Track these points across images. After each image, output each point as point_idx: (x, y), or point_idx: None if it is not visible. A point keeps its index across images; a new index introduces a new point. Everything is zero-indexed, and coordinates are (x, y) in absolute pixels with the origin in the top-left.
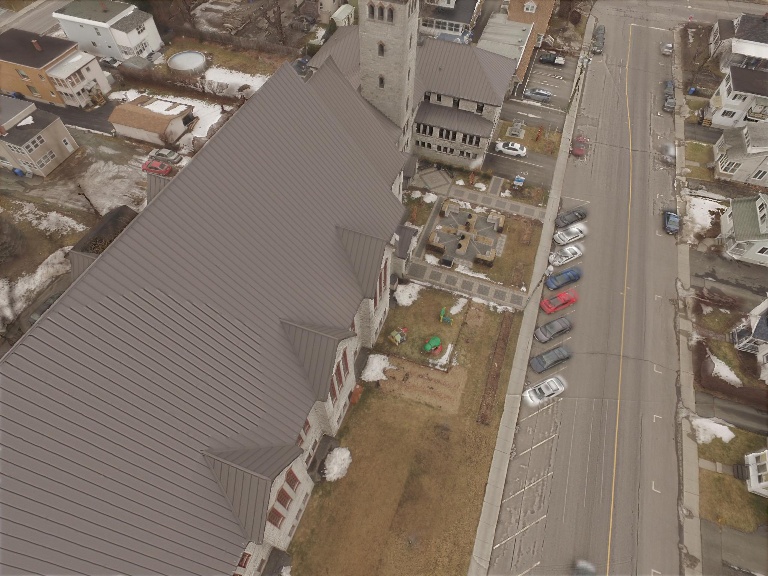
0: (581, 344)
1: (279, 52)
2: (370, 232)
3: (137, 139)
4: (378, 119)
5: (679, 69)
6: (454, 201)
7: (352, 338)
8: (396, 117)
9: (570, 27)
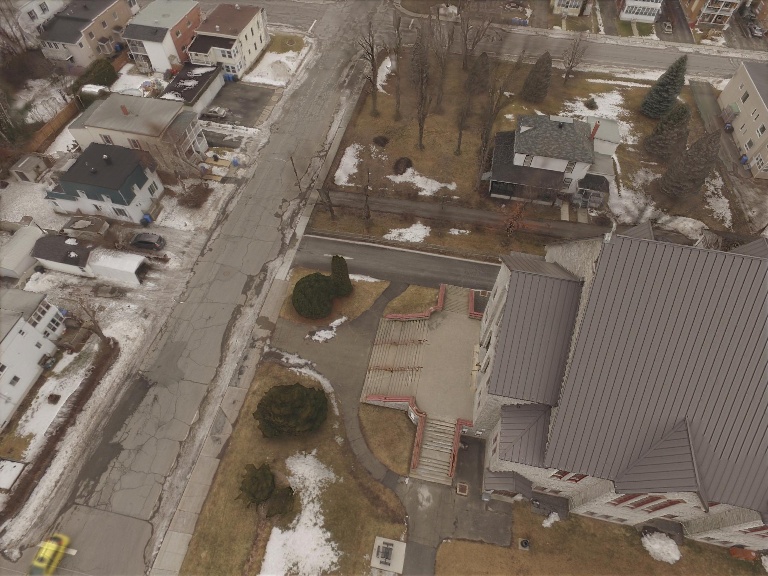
0: None
1: None
2: None
3: None
4: None
5: None
6: None
7: None
8: None
9: None
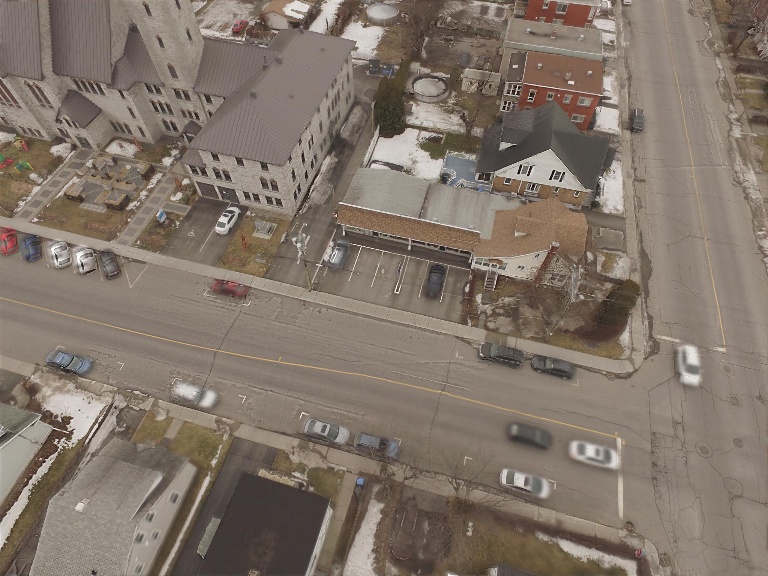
0: None
1: None
2: (2, 52)
3: None
4: None
5: (452, 491)
6: (158, 176)
7: None
8: None
9: (540, 311)
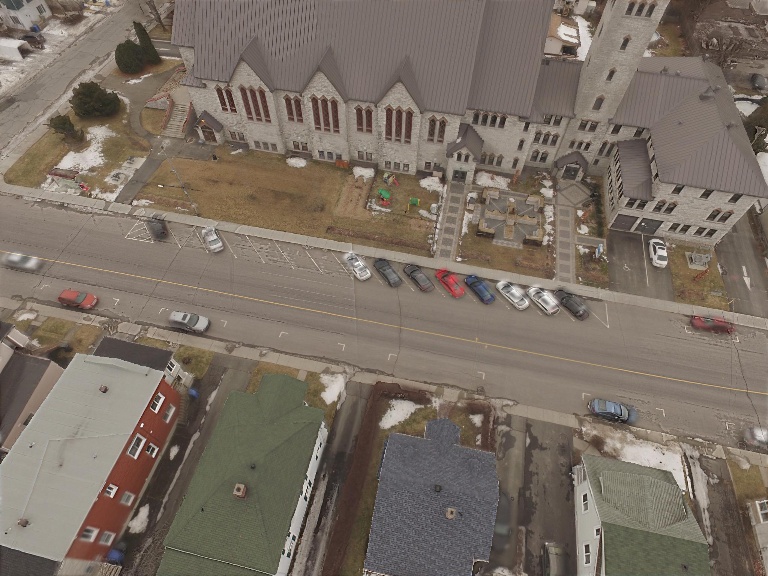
0: (408, 297)
1: None
2: (423, 88)
3: None
4: (568, 91)
5: None
6: (550, 208)
7: (367, 133)
8: (577, 100)
9: None
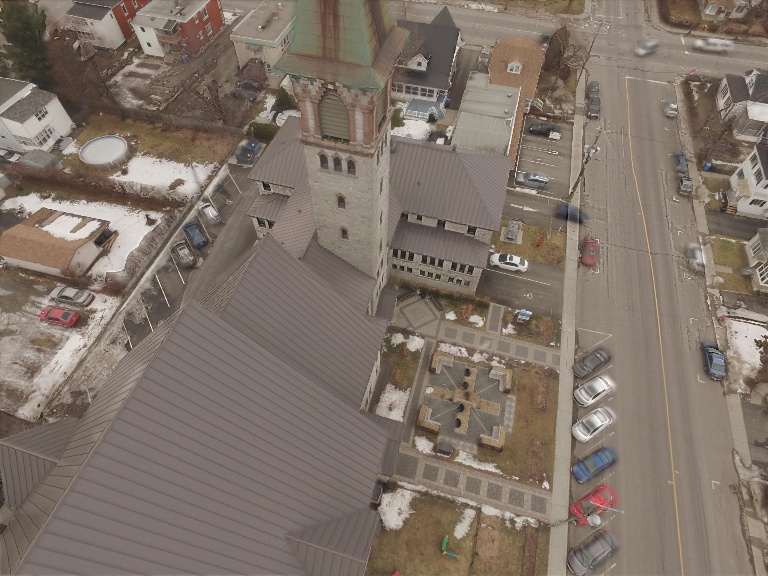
0: (630, 575)
1: (219, 132)
2: (340, 507)
3: (35, 271)
4: (343, 273)
5: (688, 135)
6: (446, 347)
7: None
8: (367, 268)
9: (560, 86)
